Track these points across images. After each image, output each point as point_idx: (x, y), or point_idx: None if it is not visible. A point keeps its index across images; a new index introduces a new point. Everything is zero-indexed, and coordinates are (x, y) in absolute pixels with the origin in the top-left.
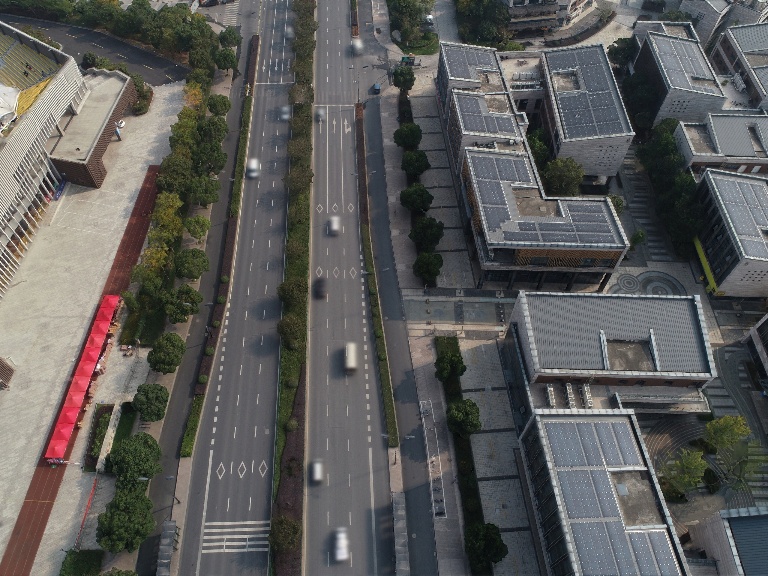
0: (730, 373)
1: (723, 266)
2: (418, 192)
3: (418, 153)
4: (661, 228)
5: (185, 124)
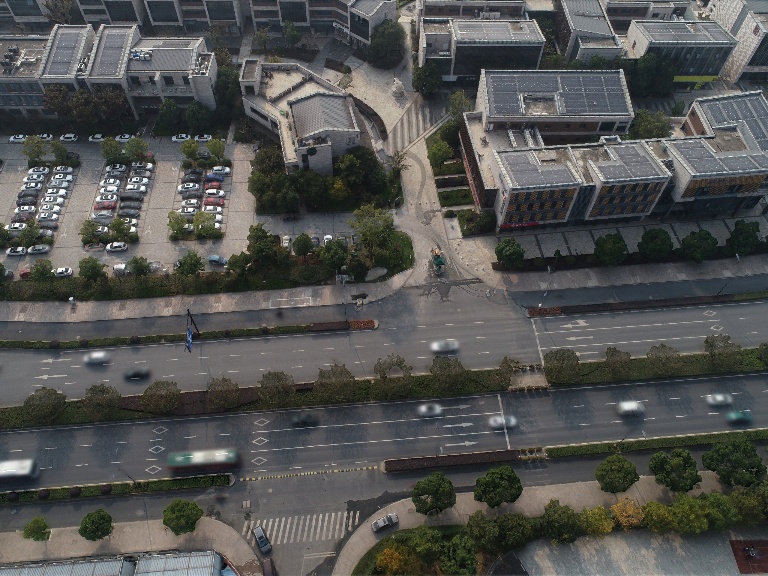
0: (764, 92)
1: (715, 63)
2: (709, 236)
3: (657, 233)
4: (641, 101)
5: (696, 505)
